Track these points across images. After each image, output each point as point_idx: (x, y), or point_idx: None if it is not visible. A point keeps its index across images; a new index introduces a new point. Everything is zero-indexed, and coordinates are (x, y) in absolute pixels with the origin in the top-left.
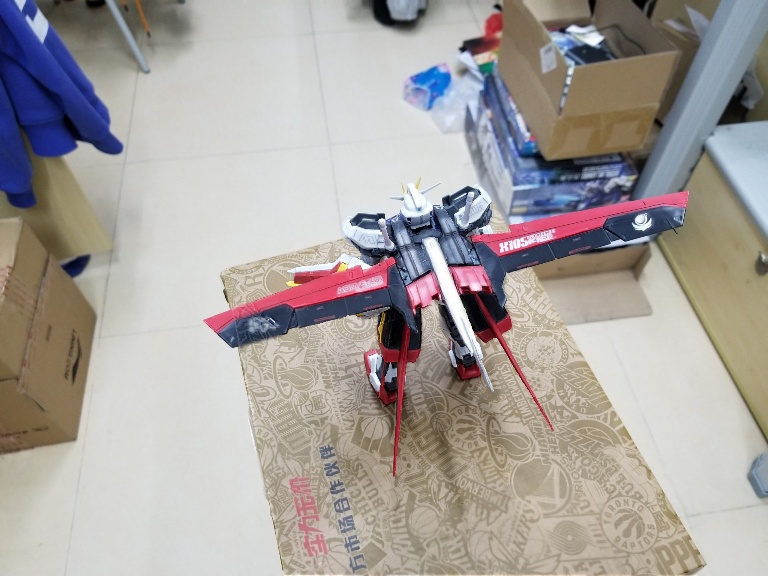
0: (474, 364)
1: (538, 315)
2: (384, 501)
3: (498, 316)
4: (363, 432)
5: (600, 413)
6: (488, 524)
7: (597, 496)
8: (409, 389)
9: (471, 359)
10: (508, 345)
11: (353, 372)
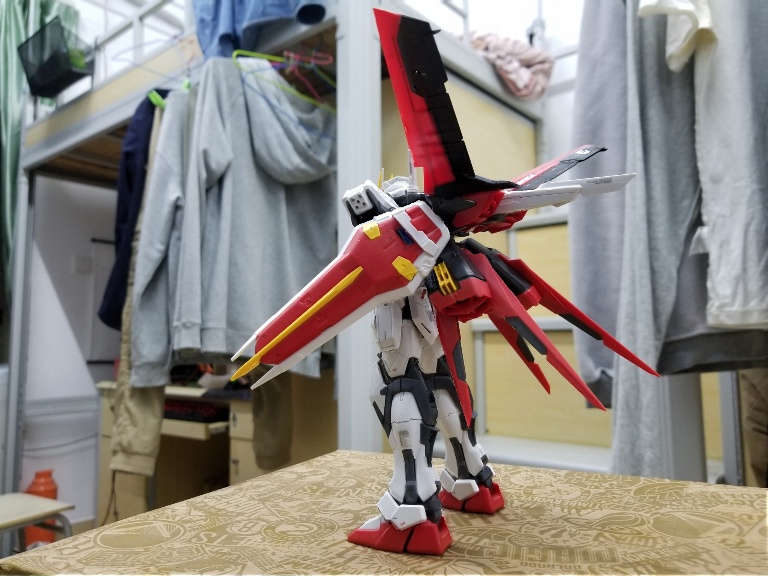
0: (491, 488)
1: None
2: None
3: None
4: None
5: (640, 481)
6: (717, 564)
7: (741, 509)
8: None
9: (488, 469)
10: None
11: (353, 554)
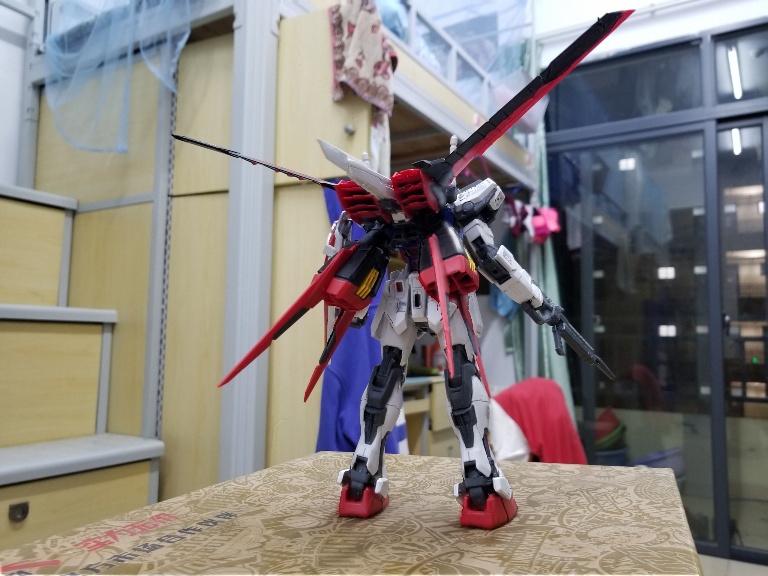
0: (486, 502)
1: (647, 516)
2: (215, 551)
3: (449, 253)
4: (284, 519)
5: None
6: None
7: None
8: (384, 517)
9: (478, 479)
10: (567, 523)
11: None
